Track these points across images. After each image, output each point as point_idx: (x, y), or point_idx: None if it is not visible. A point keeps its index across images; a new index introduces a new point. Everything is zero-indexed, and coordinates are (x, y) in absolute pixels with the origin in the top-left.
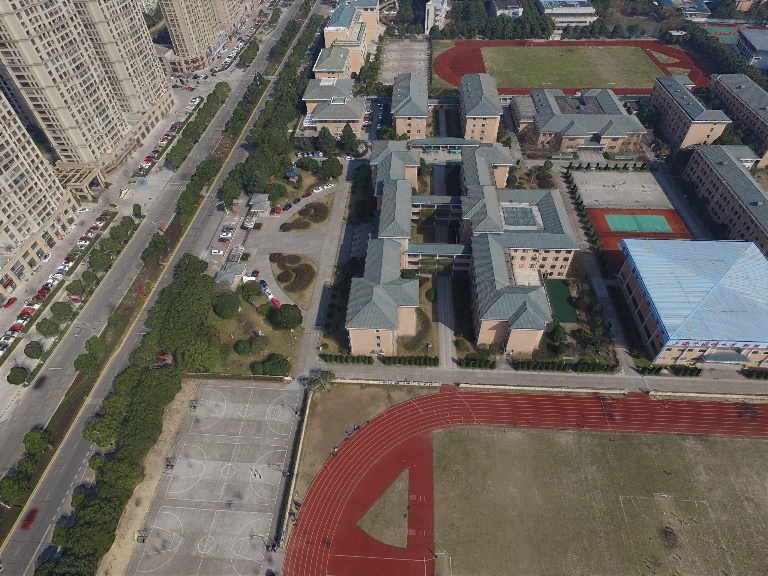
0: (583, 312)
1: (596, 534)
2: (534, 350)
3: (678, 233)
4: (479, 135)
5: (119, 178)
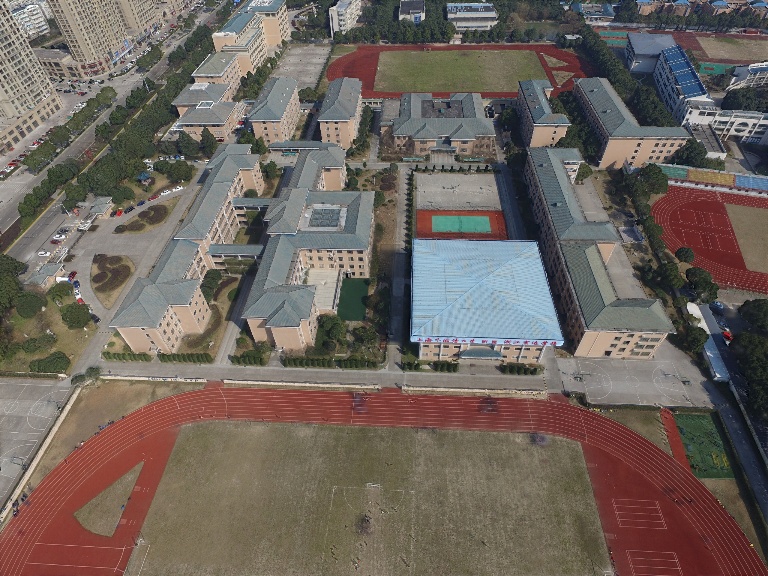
0: (371, 310)
1: (296, 522)
2: (308, 347)
3: (495, 233)
4: (335, 138)
5: None
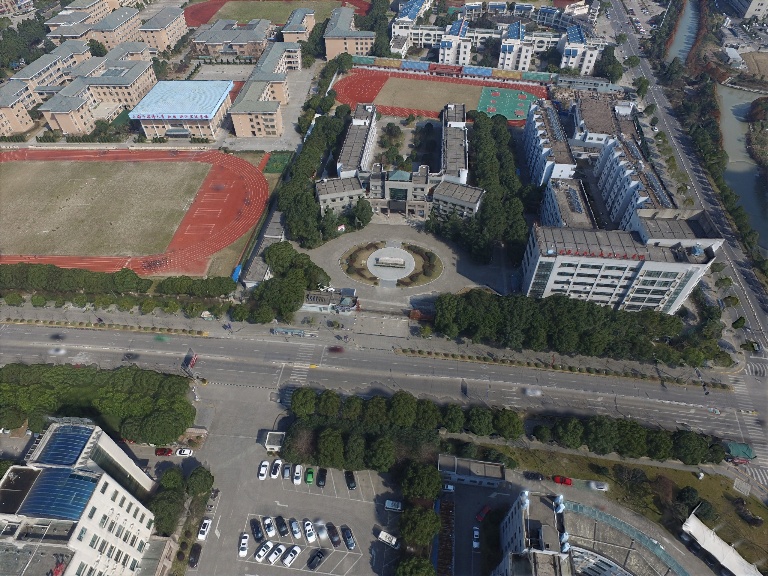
0: None
1: None
2: None
3: (233, 91)
4: (154, 44)
5: None
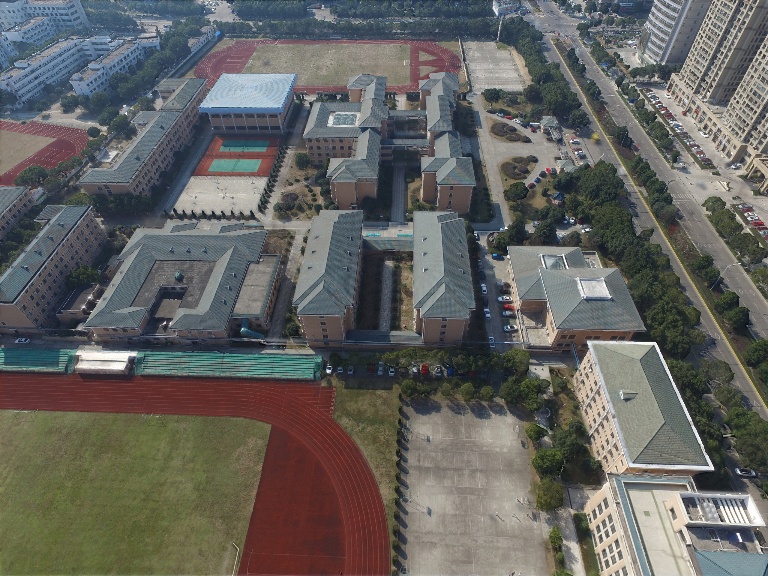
0: None
1: None
2: None
3: (212, 158)
4: None
5: (759, 202)
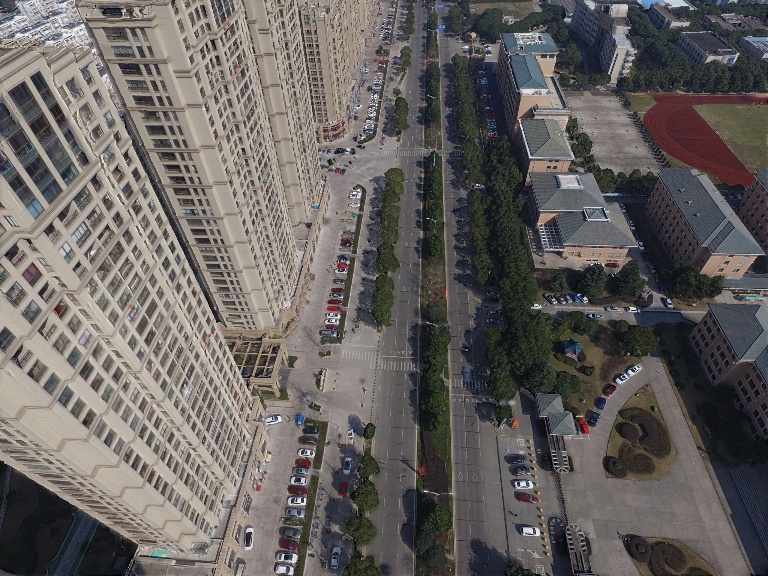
0: None
1: None
2: None
3: None
4: None
5: (303, 345)
